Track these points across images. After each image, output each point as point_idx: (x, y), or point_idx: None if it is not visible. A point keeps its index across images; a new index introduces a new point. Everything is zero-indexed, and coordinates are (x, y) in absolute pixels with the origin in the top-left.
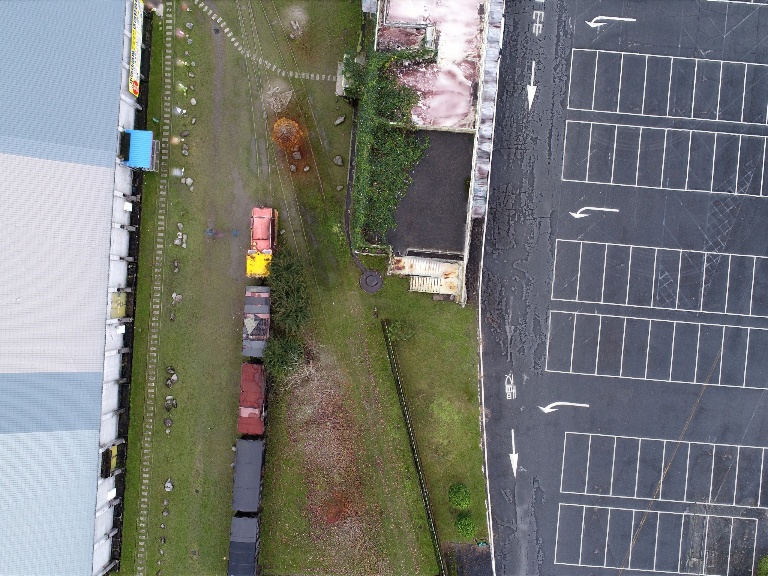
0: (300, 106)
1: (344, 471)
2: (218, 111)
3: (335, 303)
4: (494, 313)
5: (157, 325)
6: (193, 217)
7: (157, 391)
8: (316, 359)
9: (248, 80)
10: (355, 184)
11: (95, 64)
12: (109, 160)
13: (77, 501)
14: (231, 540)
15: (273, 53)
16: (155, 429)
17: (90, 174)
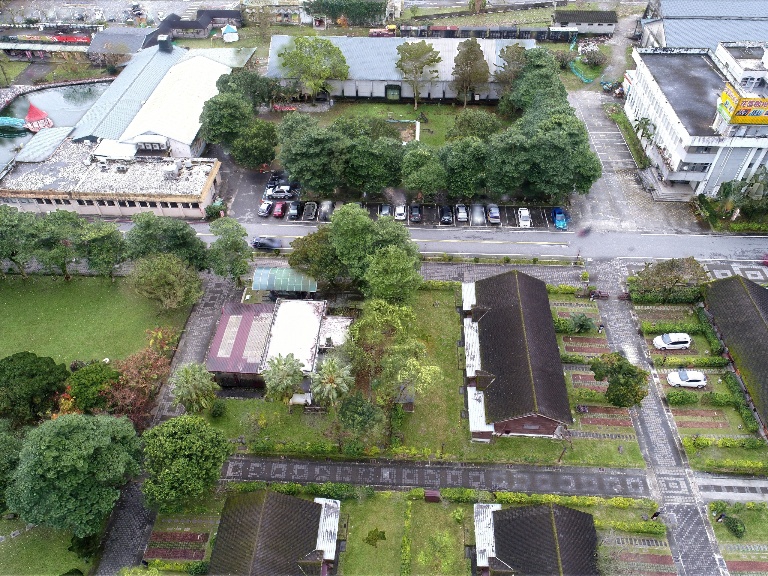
0: None
1: None
2: None
3: None
4: (407, 6)
5: None
6: None
7: None
8: None
9: None
10: (362, 7)
11: None
12: None
13: None
14: (499, 30)
15: None
16: None
17: None
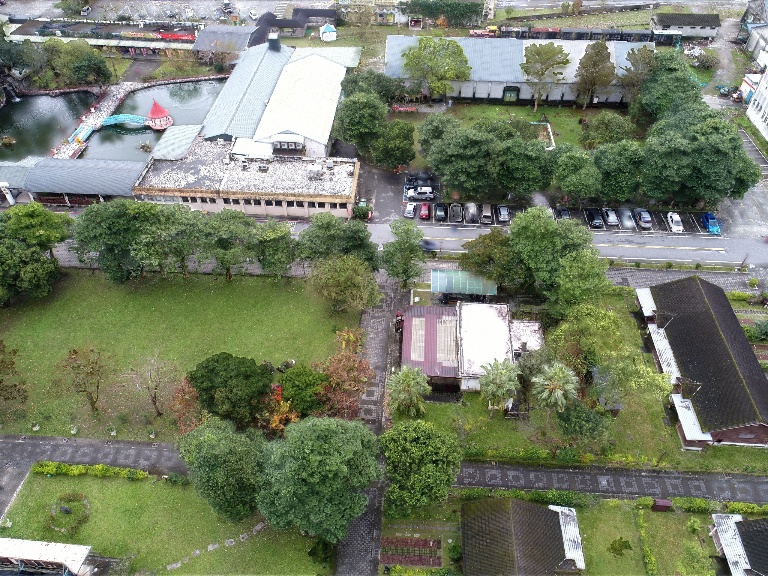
0: None
1: None
2: None
3: None
4: (497, 7)
5: None
6: None
7: None
8: None
9: None
10: (460, 8)
11: None
12: None
13: None
14: (602, 32)
15: None
16: None
17: None
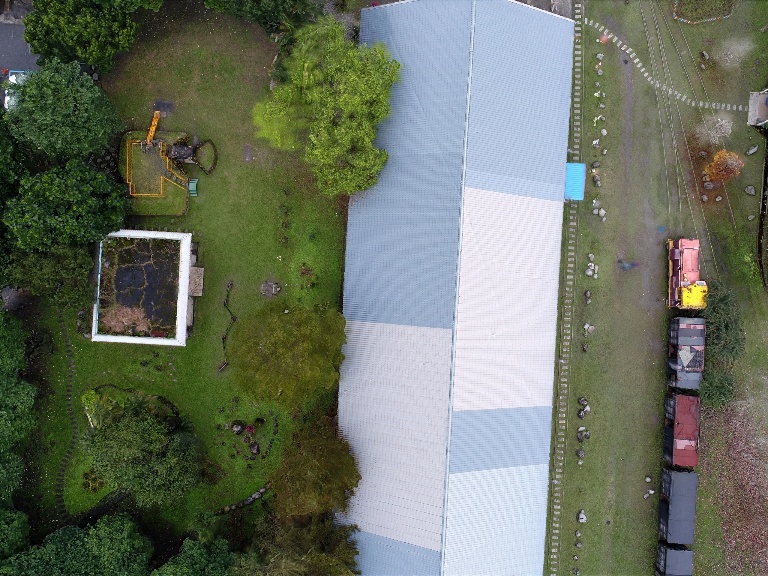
0: None
1: (757, 501)
2: (628, 141)
3: (747, 333)
4: None
5: (568, 356)
6: (603, 248)
7: (568, 422)
8: None
9: (658, 110)
10: None
11: (550, 98)
12: (559, 194)
13: (531, 536)
14: (667, 573)
15: (683, 83)
16: (566, 460)
17: (545, 208)
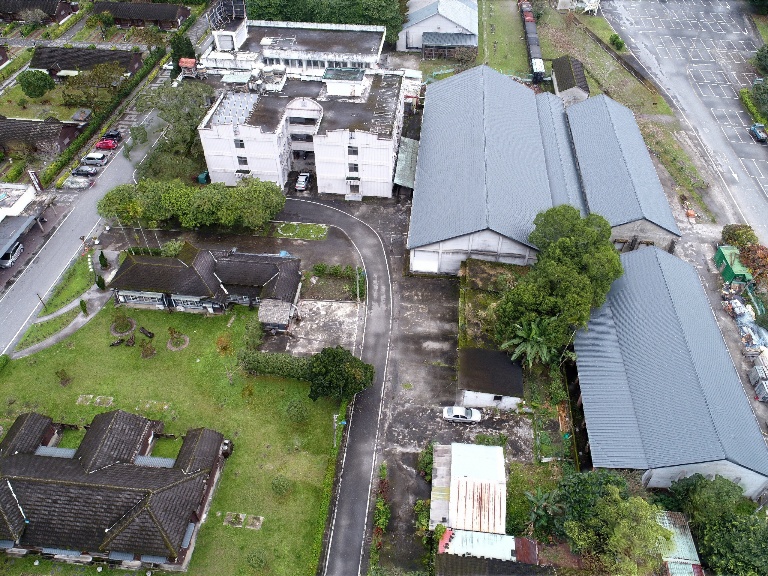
0: None
1: None
2: None
3: None
4: None
5: None
6: (495, 4)
7: None
8: (547, 24)
9: None
10: None
11: None
12: None
13: None
14: (528, 37)
15: None
16: None
17: None
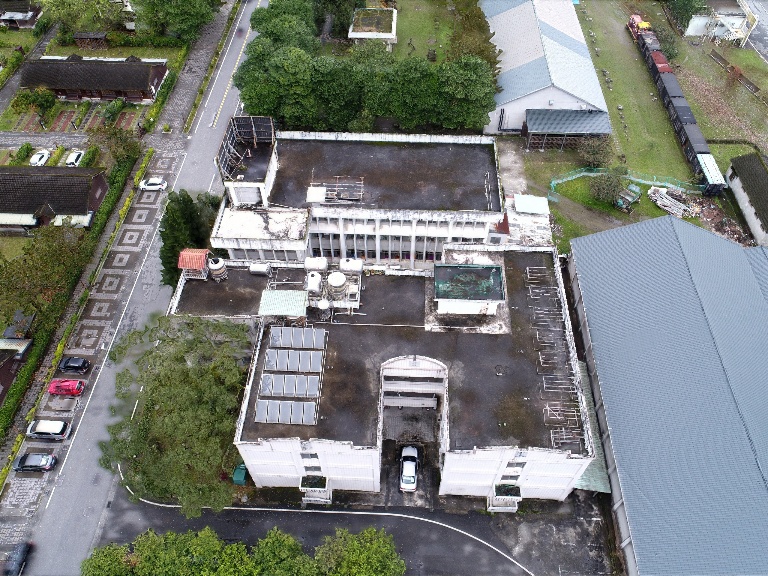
0: (633, 2)
1: None
2: None
3: (680, 51)
4: (765, 51)
5: None
6: (595, 29)
7: (599, 78)
8: None
9: None
10: None
11: None
12: None
13: None
14: (675, 106)
15: None
16: (603, 90)
17: None
